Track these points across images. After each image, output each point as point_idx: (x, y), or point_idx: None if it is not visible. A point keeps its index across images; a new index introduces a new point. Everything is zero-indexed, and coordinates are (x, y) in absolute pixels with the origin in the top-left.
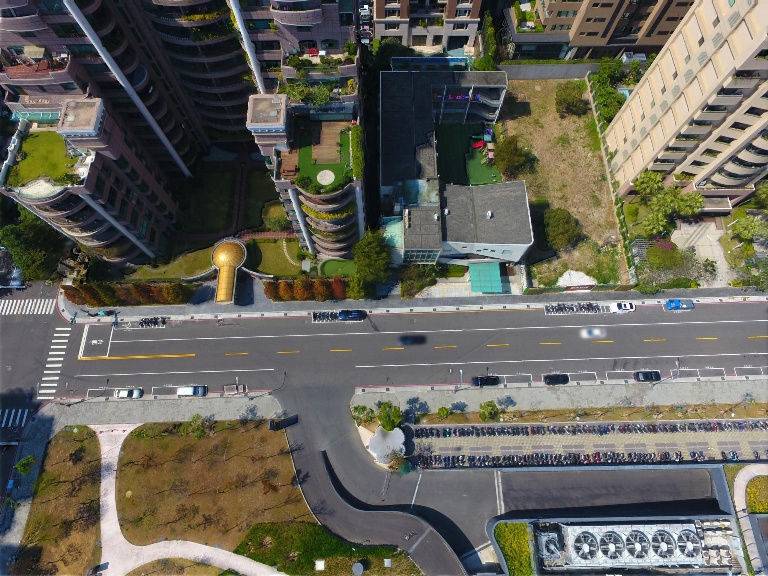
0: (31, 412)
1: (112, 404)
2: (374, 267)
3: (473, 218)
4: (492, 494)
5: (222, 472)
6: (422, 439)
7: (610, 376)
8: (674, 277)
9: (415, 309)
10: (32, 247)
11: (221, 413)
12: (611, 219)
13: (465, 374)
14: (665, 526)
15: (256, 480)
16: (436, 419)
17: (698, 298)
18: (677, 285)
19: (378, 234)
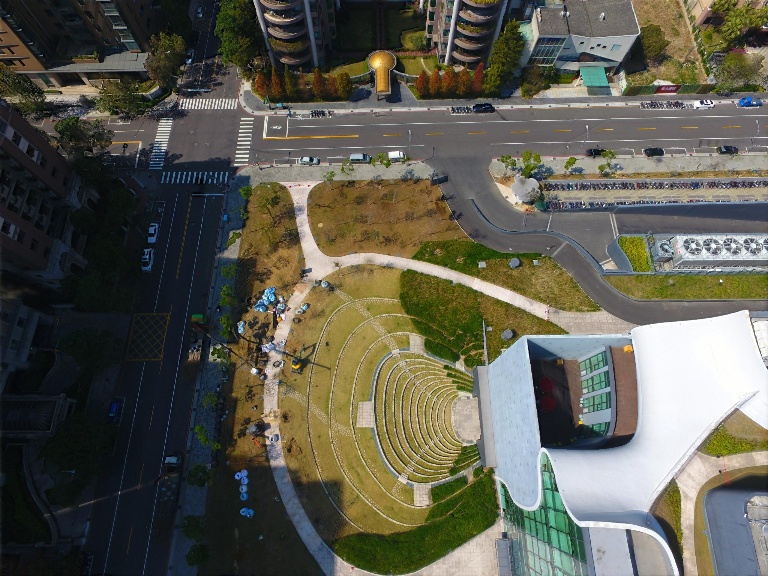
0: (231, 174)
1: (296, 168)
2: (511, 55)
3: (588, 21)
4: (609, 229)
5: (393, 210)
6: (550, 192)
7: (697, 151)
8: (746, 80)
9: (534, 106)
10: (239, 35)
11: (385, 174)
12: (689, 45)
13: (580, 149)
14: (752, 236)
15: (421, 216)
16: (560, 177)
17: (764, 99)
18: (747, 88)
19: (518, 24)
